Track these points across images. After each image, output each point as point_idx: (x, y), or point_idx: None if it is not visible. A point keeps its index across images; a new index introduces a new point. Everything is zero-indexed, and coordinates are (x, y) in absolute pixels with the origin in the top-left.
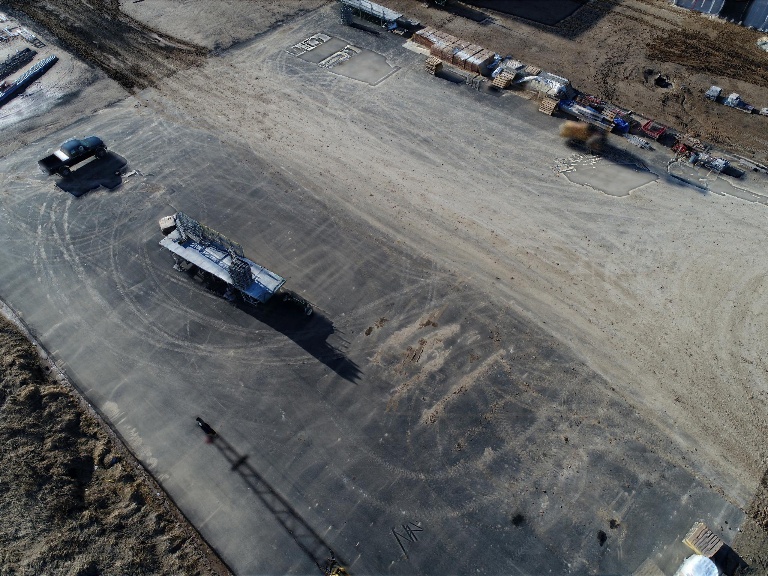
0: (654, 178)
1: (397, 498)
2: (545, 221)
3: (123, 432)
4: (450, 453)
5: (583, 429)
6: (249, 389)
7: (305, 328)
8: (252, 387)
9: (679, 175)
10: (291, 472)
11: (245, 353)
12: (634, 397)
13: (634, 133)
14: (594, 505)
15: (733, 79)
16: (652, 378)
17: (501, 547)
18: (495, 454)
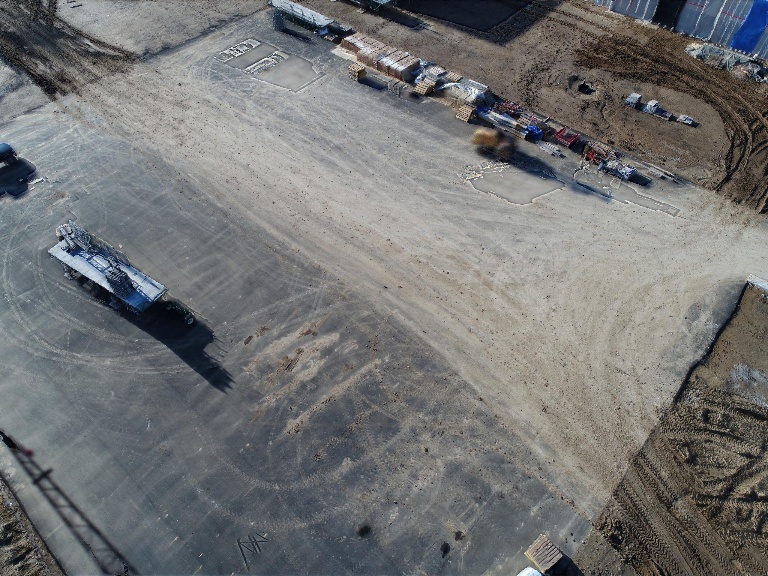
0: (560, 186)
1: (248, 509)
2: (443, 229)
3: None
4: (308, 463)
5: (445, 440)
6: (119, 398)
7: (185, 337)
8: (122, 396)
9: (584, 183)
10: (147, 482)
11: (121, 362)
12: (501, 407)
13: (548, 140)
14: (443, 516)
15: (657, 86)
16: (522, 388)
17: (343, 559)
18: (353, 465)
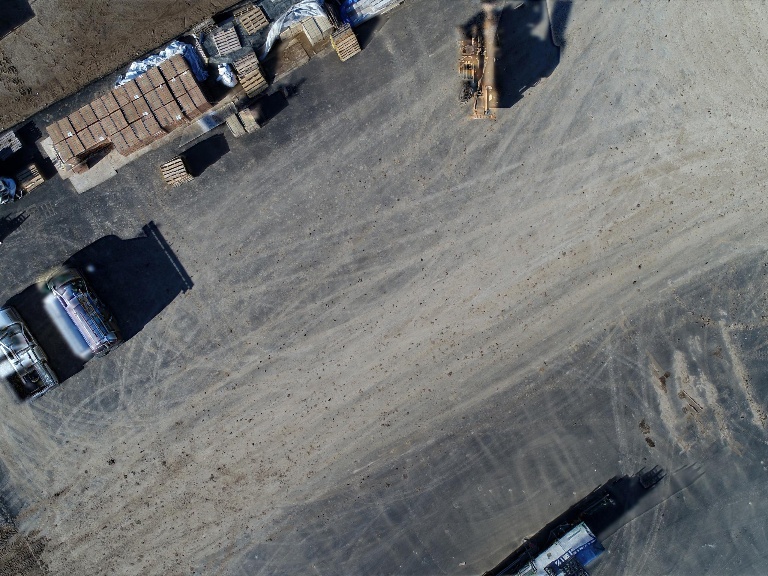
0: None
1: None
2: (569, 182)
3: None
4: None
5: None
6: (672, 571)
7: (623, 504)
8: (671, 568)
9: None
10: (764, 550)
11: (631, 568)
12: None
13: None
14: None
15: None
16: None
17: None
18: None
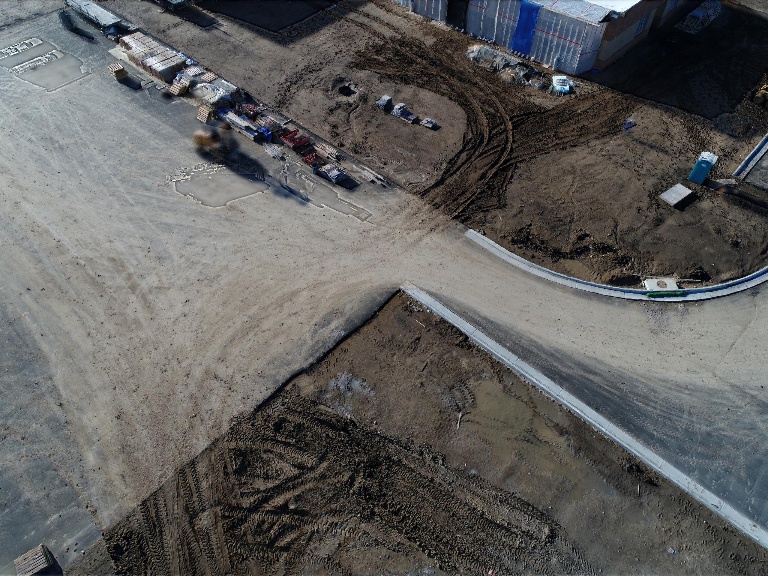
0: (263, 189)
1: None
2: (119, 231)
3: None
4: None
5: (3, 445)
6: None
7: None
8: None
9: (285, 186)
10: None
11: None
12: (76, 413)
13: (277, 142)
14: None
15: (419, 88)
16: (108, 394)
17: None
18: None
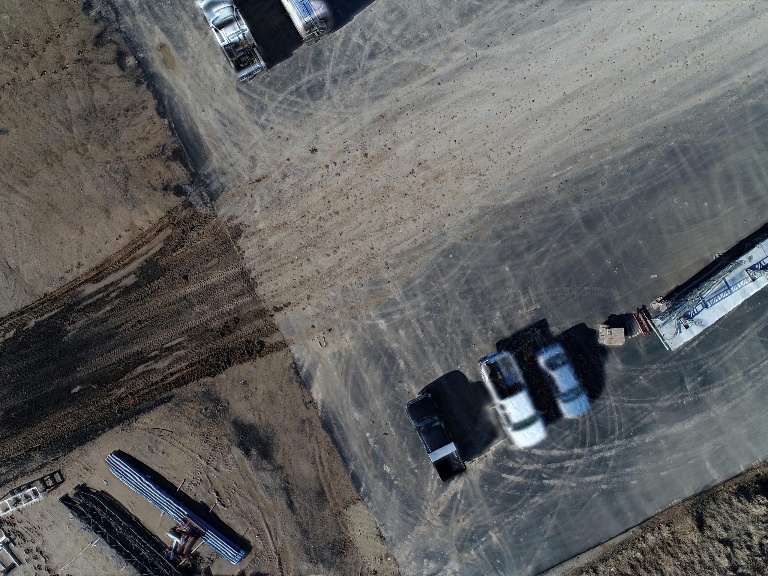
0: None
1: None
2: None
3: None
4: None
5: None
6: None
7: None
8: None
9: None
10: None
11: None
12: None
13: None
14: None
15: None
16: None
17: None
18: None
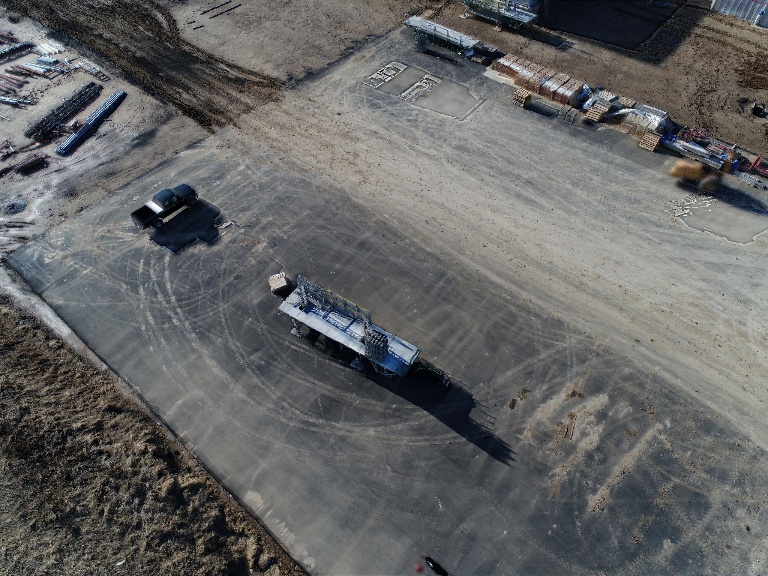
0: None
1: None
2: (673, 273)
3: (272, 527)
4: (627, 547)
5: (763, 516)
6: (398, 474)
7: (444, 401)
8: (401, 472)
9: None
10: (461, 572)
11: (386, 432)
12: None
13: (744, 170)
14: None
15: None
16: None
17: None
18: (675, 547)
